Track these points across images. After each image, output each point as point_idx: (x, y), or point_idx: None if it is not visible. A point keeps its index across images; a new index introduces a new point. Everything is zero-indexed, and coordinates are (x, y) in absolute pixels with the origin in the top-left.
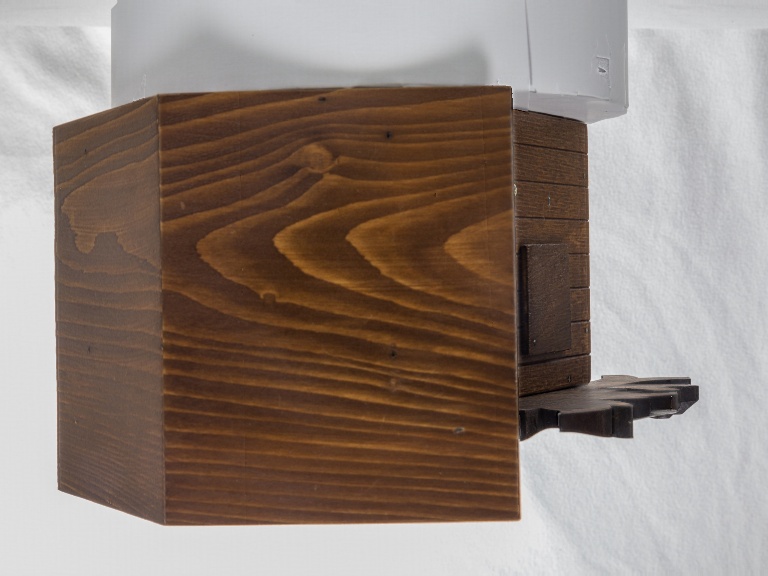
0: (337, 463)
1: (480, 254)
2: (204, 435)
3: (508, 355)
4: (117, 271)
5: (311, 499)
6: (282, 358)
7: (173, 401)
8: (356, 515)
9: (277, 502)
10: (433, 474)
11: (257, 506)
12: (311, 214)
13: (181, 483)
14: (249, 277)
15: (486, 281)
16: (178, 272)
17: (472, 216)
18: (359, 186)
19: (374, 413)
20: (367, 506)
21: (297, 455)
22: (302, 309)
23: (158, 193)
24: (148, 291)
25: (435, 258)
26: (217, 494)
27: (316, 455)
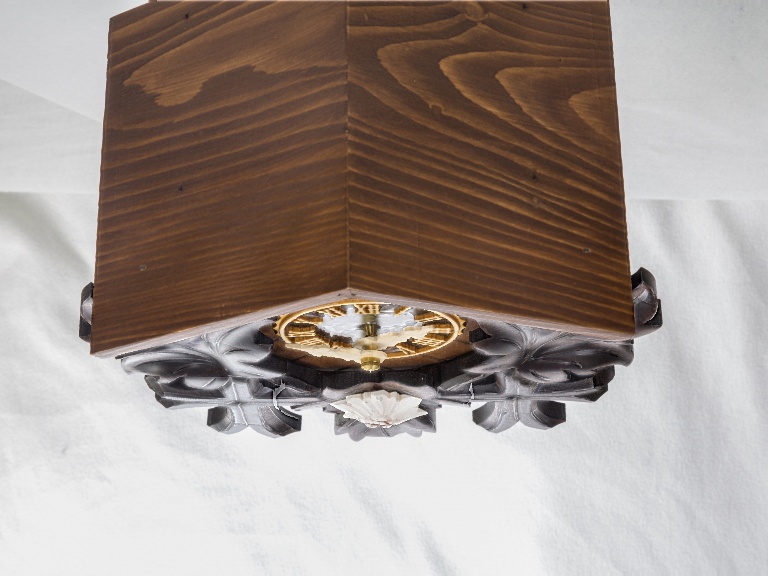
0: (494, 259)
1: (595, 114)
2: (383, 213)
3: (619, 197)
4: (252, 96)
5: (474, 286)
6: (447, 161)
7: (357, 178)
8: (510, 307)
9: (446, 284)
10: (569, 283)
11: (429, 284)
12: (468, 51)
13: (363, 251)
14: (420, 88)
15: (600, 136)
16: (362, 70)
17: (587, 84)
18: (504, 39)
19: (522, 222)
20: (519, 301)
21: (461, 246)
22: (463, 124)
23: (344, 3)
24: (319, 91)
25: (562, 109)
26: (394, 267)
27: (477, 249)
